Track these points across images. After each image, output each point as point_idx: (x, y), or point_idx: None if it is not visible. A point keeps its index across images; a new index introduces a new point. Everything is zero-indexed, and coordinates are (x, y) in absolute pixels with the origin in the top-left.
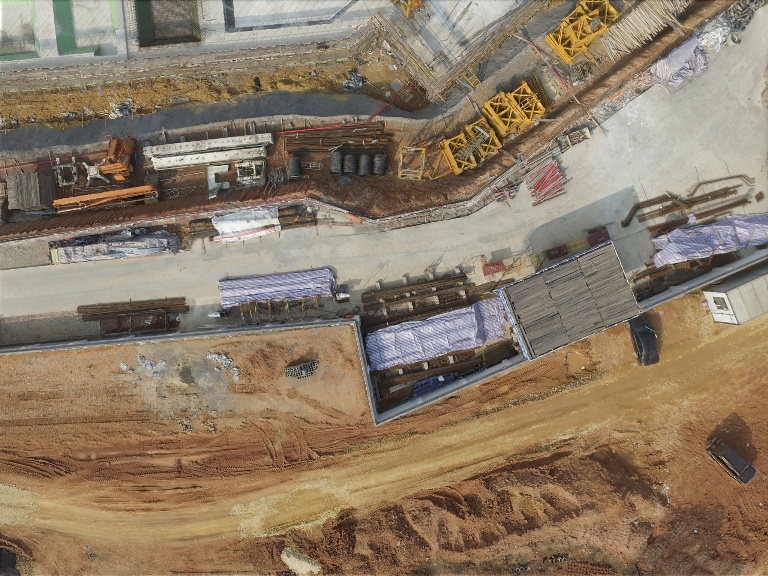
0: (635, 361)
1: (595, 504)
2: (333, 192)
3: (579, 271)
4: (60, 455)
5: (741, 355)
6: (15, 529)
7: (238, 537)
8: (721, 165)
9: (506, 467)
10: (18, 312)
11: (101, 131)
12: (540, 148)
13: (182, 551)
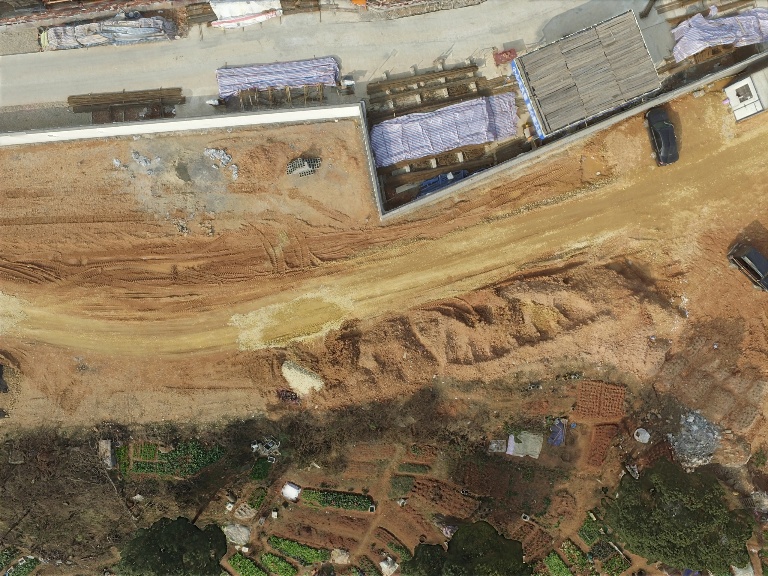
0: (653, 163)
1: (611, 311)
2: None
3: (597, 40)
4: (50, 259)
5: (764, 160)
6: (2, 339)
7: (236, 350)
8: None
9: (518, 277)
10: (5, 102)
11: None
12: None
13: (178, 364)
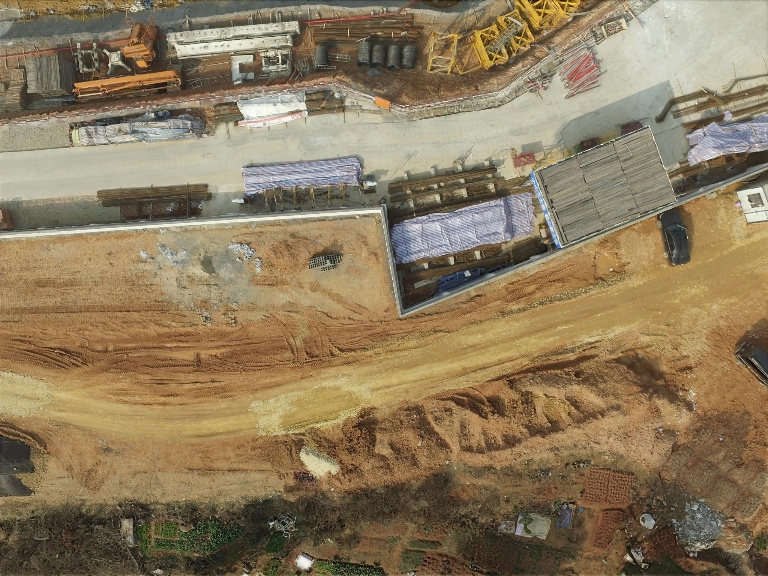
0: (665, 262)
1: (621, 406)
2: (361, 80)
3: (615, 155)
4: (77, 346)
5: None
6: (30, 421)
7: (256, 434)
8: (759, 62)
9: (530, 369)
10: (37, 195)
11: (122, 22)
12: (574, 39)
13: (199, 447)
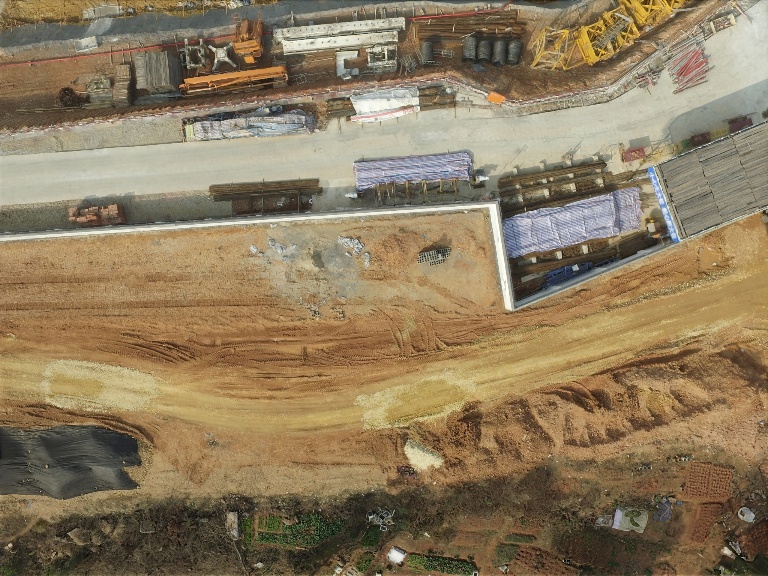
0: None
1: (726, 400)
2: (471, 75)
3: (734, 150)
4: (185, 340)
5: None
6: (137, 415)
7: (361, 428)
8: None
9: (634, 363)
10: (149, 190)
11: (223, 18)
12: None
13: (304, 441)
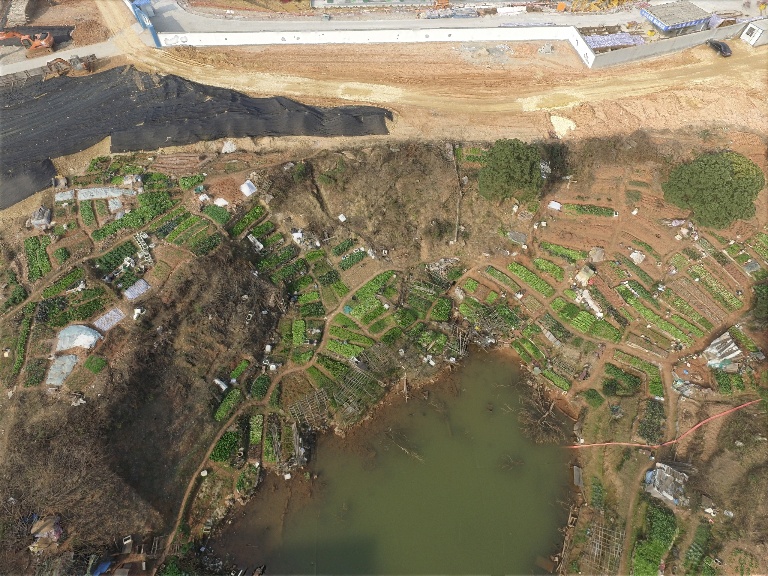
0: (720, 57)
1: None
2: None
3: (676, 5)
4: (418, 77)
5: None
6: (390, 103)
7: (522, 111)
8: (722, 8)
9: None
10: None
11: None
12: None
13: (489, 115)
